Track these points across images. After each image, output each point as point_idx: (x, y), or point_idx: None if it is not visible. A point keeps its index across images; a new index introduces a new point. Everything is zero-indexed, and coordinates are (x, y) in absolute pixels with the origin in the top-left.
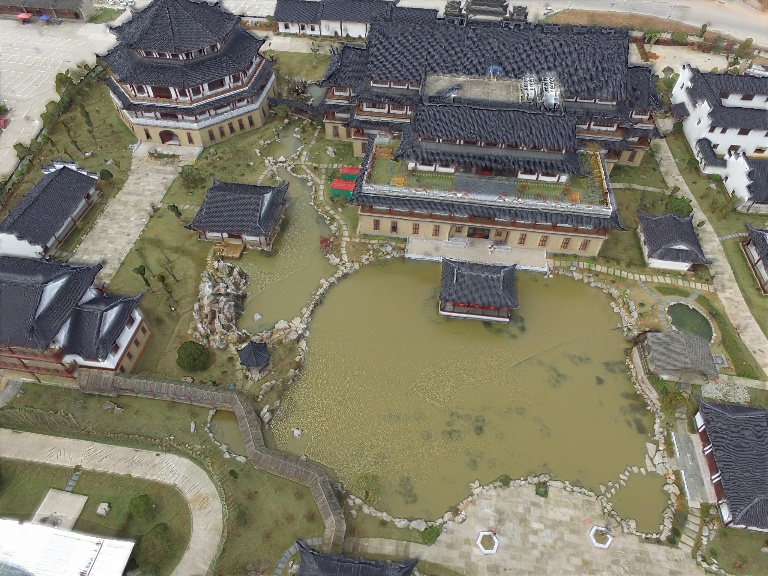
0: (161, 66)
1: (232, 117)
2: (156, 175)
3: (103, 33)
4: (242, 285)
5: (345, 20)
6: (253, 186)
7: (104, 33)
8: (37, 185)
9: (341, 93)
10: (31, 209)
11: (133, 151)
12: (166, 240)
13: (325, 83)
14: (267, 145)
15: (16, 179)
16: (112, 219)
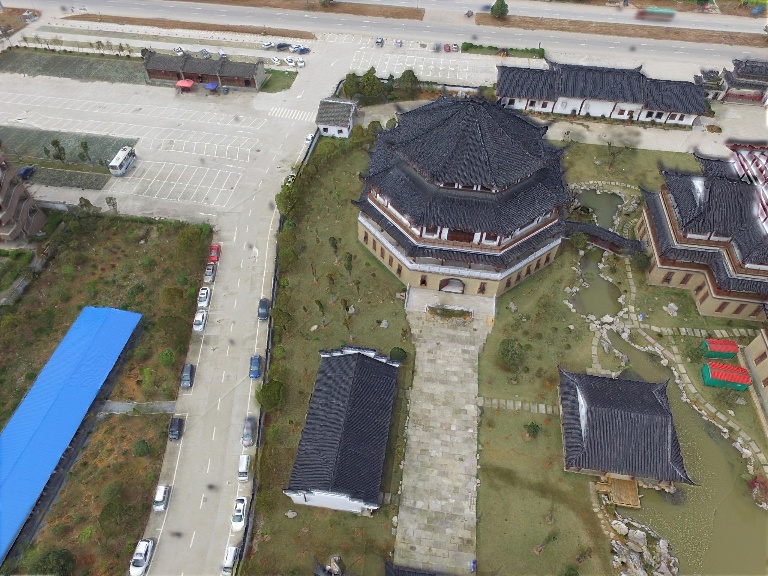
0: (466, 201)
1: (534, 258)
2: (451, 345)
3: (284, 107)
4: (674, 568)
5: (592, 98)
6: (619, 382)
7: (285, 107)
8: (320, 379)
9: (699, 236)
10: (345, 437)
11: (405, 304)
12: (519, 471)
13: (688, 227)
14: (575, 293)
15: (264, 350)
16: (426, 428)
